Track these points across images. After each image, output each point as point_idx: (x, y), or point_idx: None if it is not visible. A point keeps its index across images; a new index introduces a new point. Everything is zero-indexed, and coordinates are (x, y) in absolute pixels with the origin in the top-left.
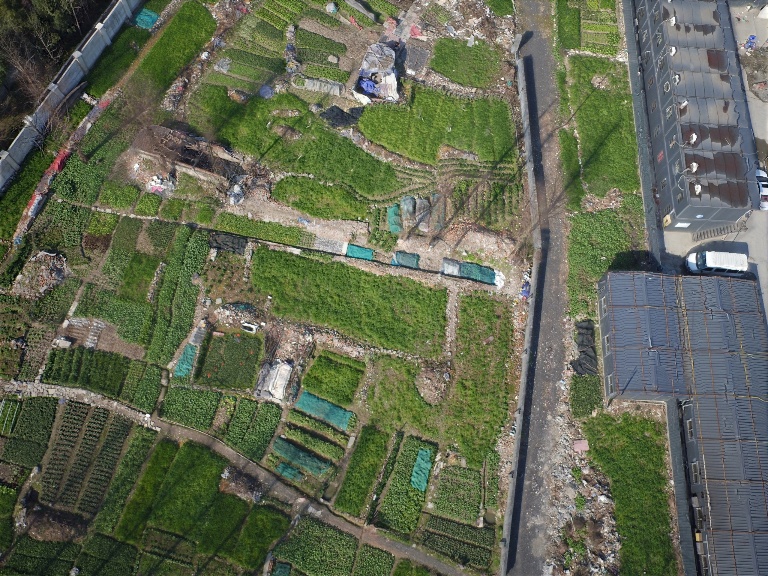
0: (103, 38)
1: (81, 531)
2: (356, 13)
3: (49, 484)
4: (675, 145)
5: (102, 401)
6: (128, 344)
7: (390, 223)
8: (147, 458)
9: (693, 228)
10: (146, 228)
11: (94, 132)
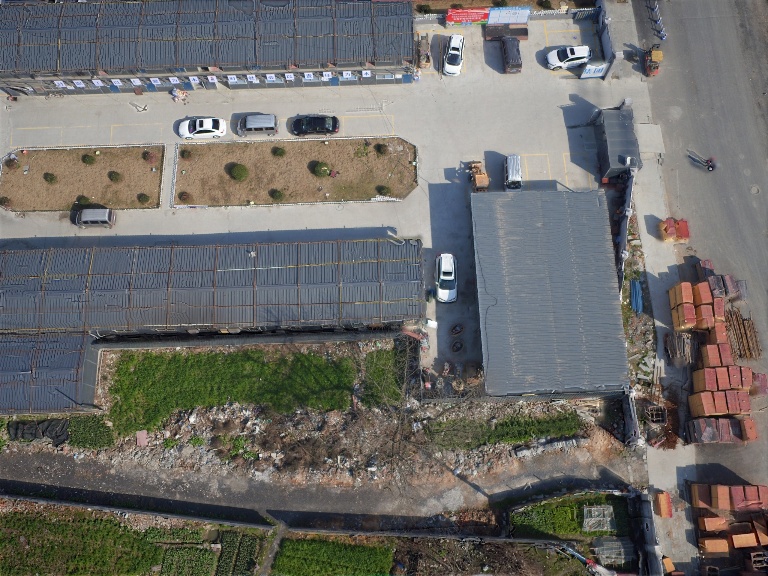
0: None
1: None
2: None
3: None
4: None
5: None
6: None
7: None
8: None
9: None
10: None
11: None
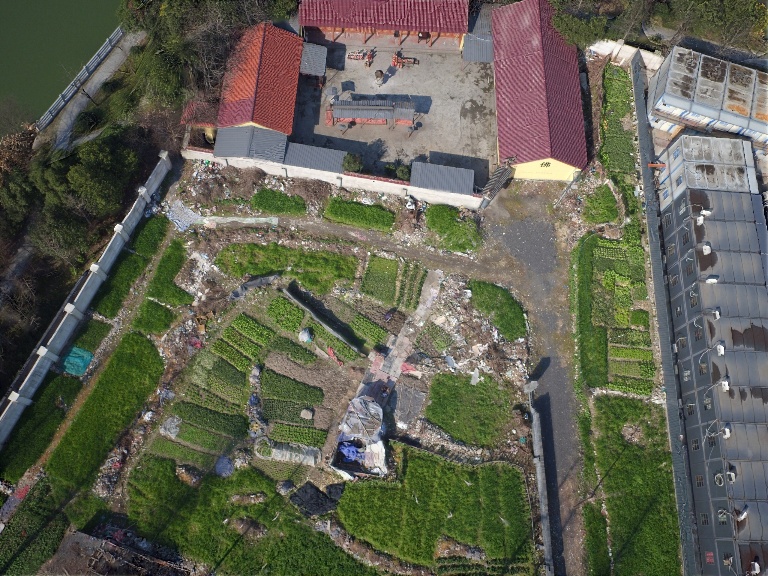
0: (20, 403)
1: None
2: (335, 342)
3: None
4: (732, 572)
5: None
6: None
7: None
8: None
9: None
10: None
11: (8, 536)
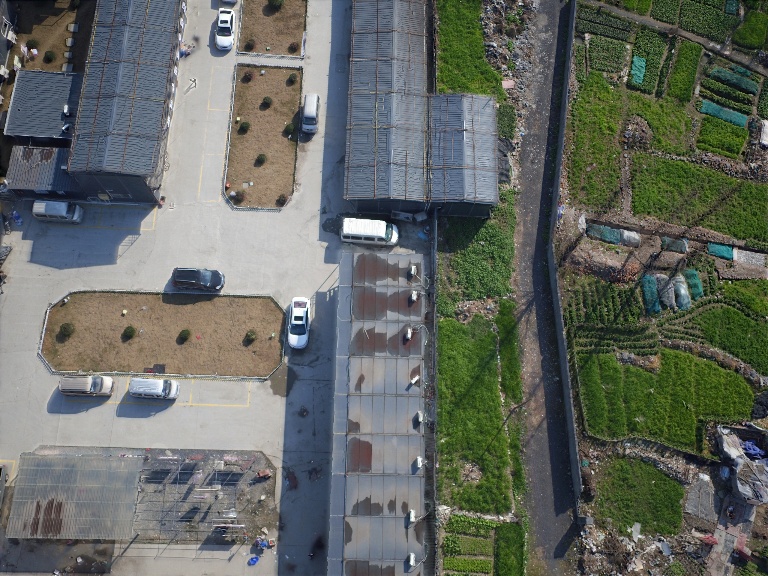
0: None
1: None
2: None
3: None
4: None
5: None
6: None
7: (698, 279)
8: None
9: None
10: None
11: None
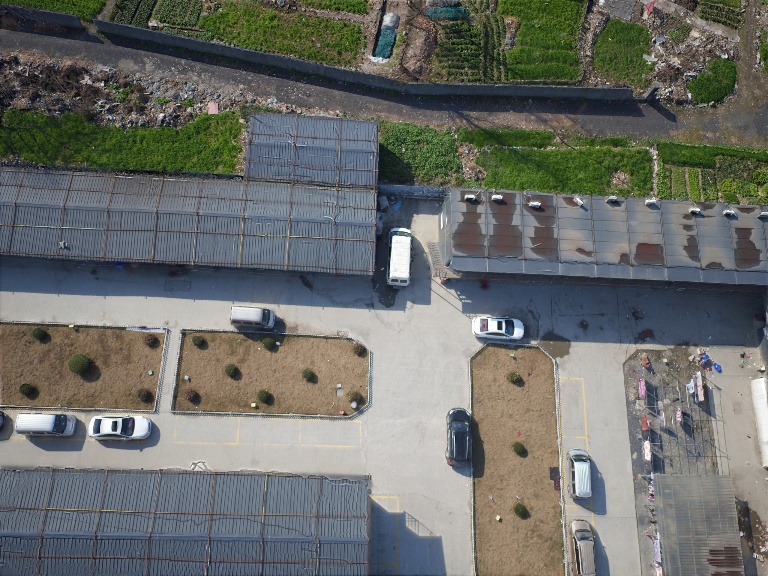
0: None
1: None
2: None
3: None
4: None
5: None
6: None
7: None
8: None
9: None
10: None
11: None
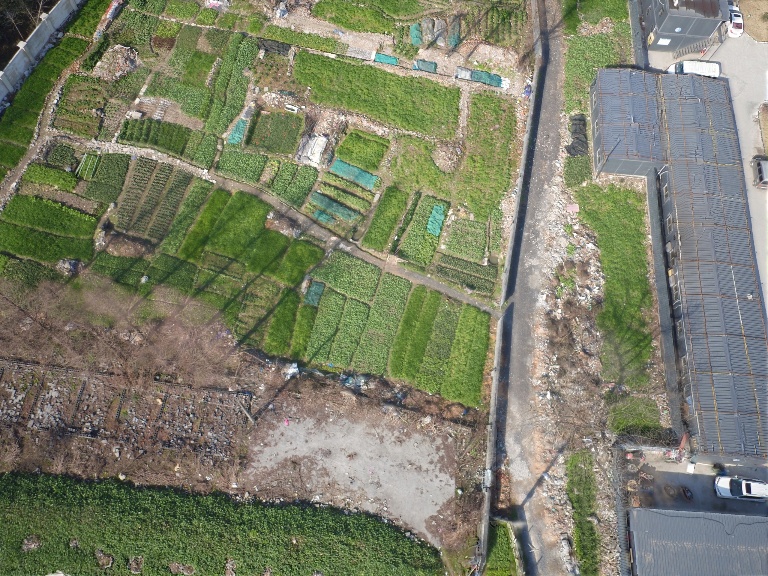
0: None
1: (150, 250)
2: None
3: (123, 216)
4: None
5: (167, 159)
6: (189, 118)
7: (412, 37)
8: (205, 202)
9: (673, 46)
10: (205, 34)
11: None
